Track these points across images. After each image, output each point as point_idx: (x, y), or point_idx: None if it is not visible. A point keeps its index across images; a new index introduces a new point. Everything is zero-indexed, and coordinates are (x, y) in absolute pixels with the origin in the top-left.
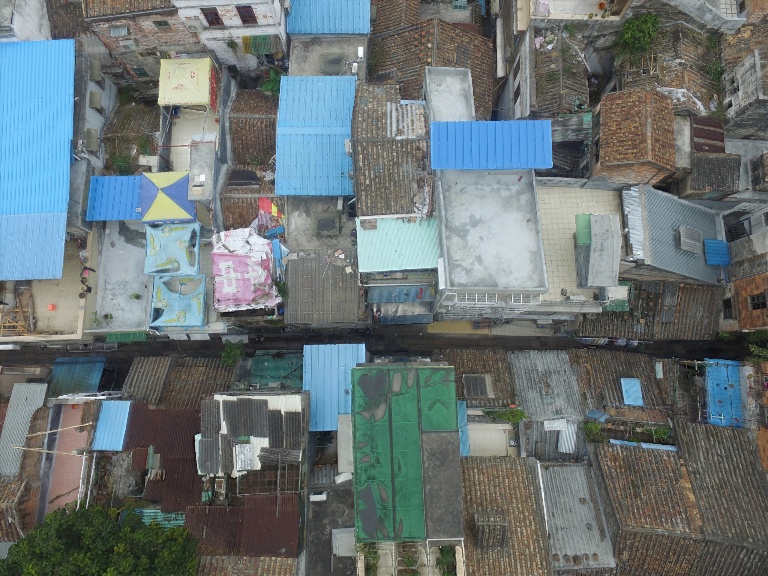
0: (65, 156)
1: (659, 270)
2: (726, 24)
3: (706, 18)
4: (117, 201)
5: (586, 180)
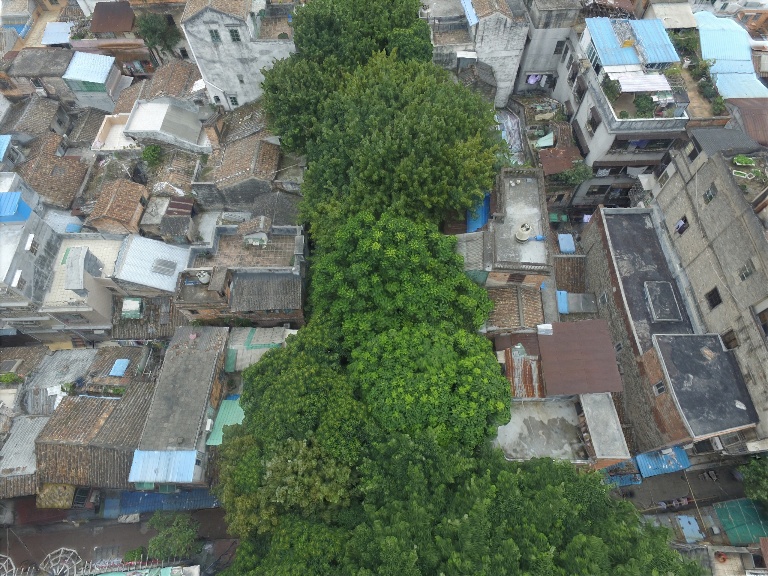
0: None
1: None
2: (203, 149)
3: (188, 146)
4: None
5: (100, 233)
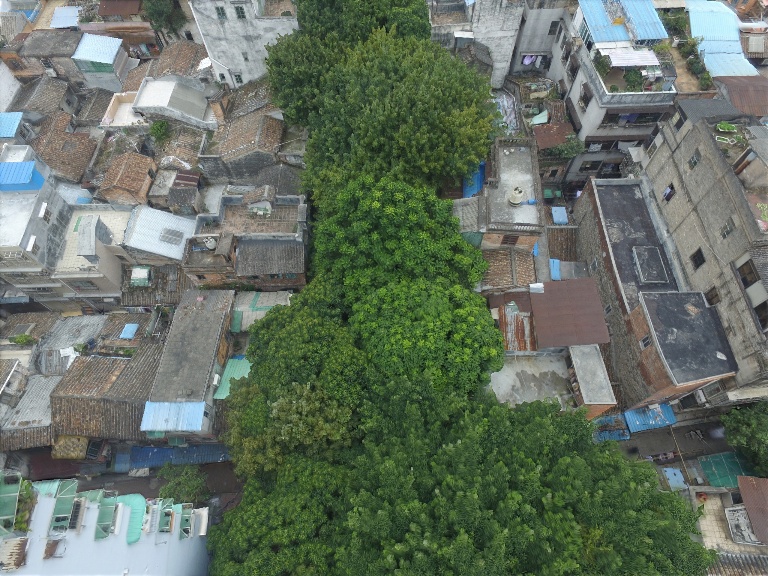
0: None
1: (142, 251)
2: (208, 125)
3: (194, 122)
4: None
5: (110, 204)
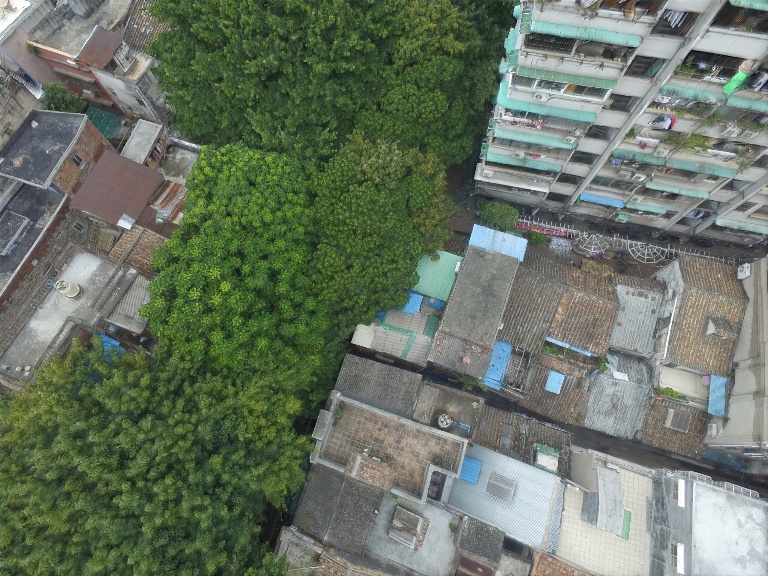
0: None
1: None
2: None
3: None
4: None
5: None
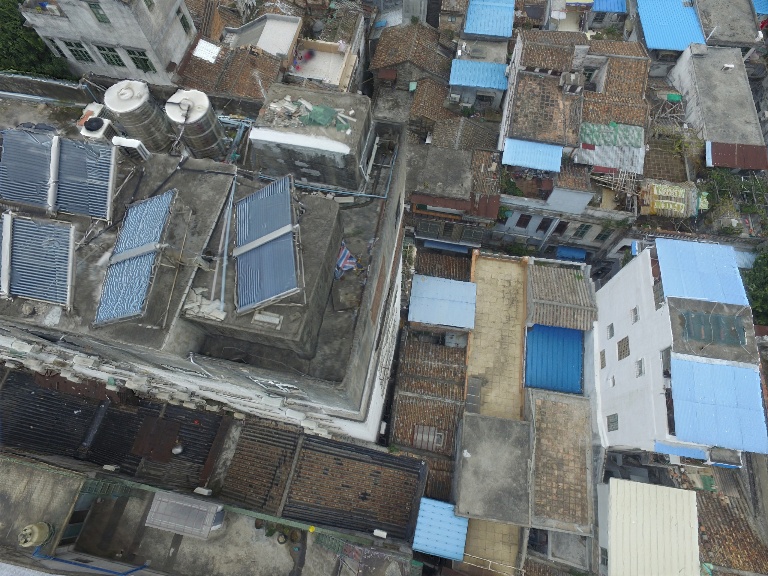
0: (640, 2)
1: None
2: None
3: None
4: (608, 0)
5: None
